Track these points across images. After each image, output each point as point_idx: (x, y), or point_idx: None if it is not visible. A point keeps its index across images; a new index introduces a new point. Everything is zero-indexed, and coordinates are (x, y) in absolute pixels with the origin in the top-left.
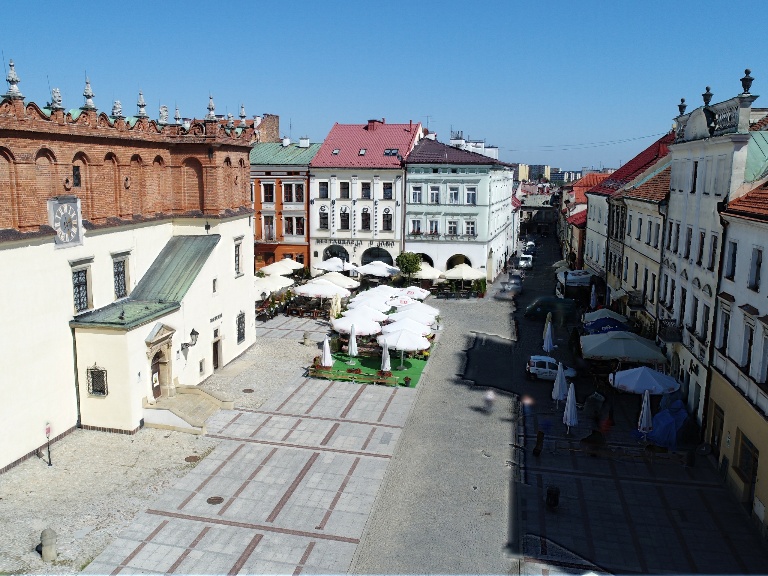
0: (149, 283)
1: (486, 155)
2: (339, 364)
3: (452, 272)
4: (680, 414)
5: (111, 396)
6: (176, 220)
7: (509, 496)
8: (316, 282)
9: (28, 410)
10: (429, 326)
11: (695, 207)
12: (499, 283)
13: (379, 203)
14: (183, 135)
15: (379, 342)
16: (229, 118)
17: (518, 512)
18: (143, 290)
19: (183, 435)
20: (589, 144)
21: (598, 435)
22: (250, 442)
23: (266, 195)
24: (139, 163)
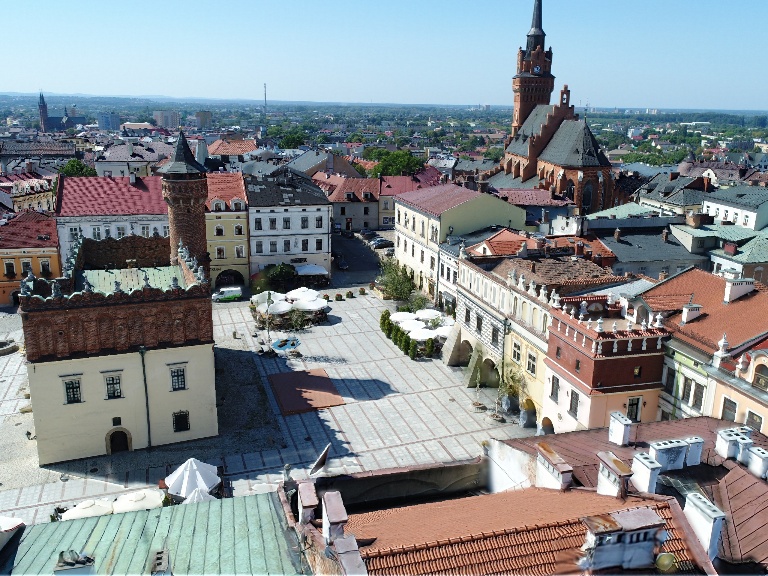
0: None
1: None
2: None
3: None
4: None
5: None
6: None
7: None
8: None
9: None
10: None
11: None
12: None
13: None
14: None
15: None
16: None
17: None
18: None
19: None
20: None
21: None
22: (1, 400)
23: None
24: None
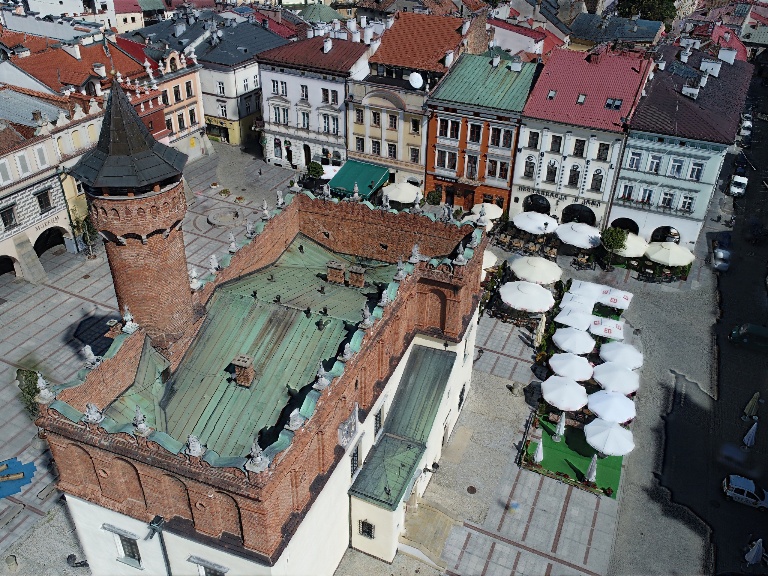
0: (398, 411)
1: (720, 58)
2: (546, 439)
3: (658, 254)
4: None
5: (377, 540)
6: (418, 334)
7: None
8: (523, 290)
9: (324, 570)
10: None
11: None
12: (704, 236)
13: (591, 163)
14: (431, 270)
15: (587, 439)
16: (473, 238)
17: None
18: (393, 420)
19: (429, 570)
20: None
21: None
22: None
23: (472, 135)
24: (395, 318)
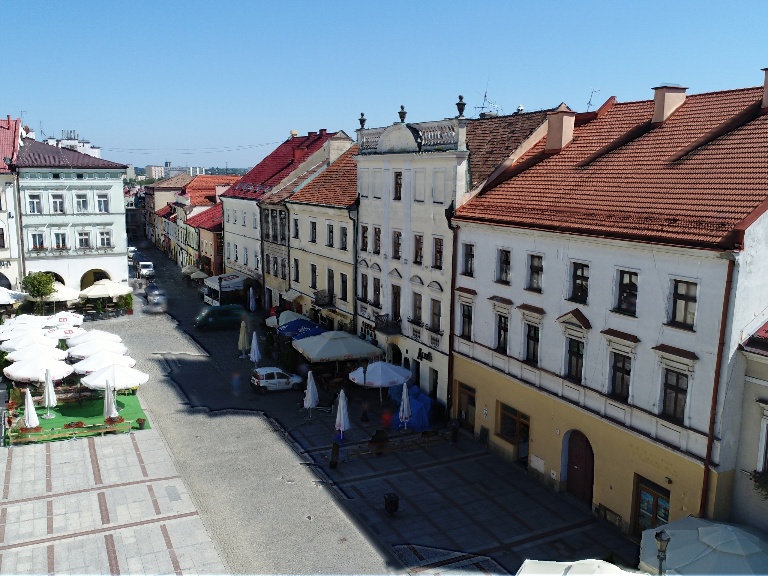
0: None
1: None
2: None
3: (94, 290)
4: (423, 398)
5: None
6: None
7: (346, 515)
8: None
9: None
10: (128, 356)
11: (403, 213)
12: (134, 296)
13: None
14: None
15: (90, 385)
16: None
17: (367, 528)
18: None
19: None
20: (223, 148)
21: (382, 434)
22: (6, 550)
23: None
24: None
